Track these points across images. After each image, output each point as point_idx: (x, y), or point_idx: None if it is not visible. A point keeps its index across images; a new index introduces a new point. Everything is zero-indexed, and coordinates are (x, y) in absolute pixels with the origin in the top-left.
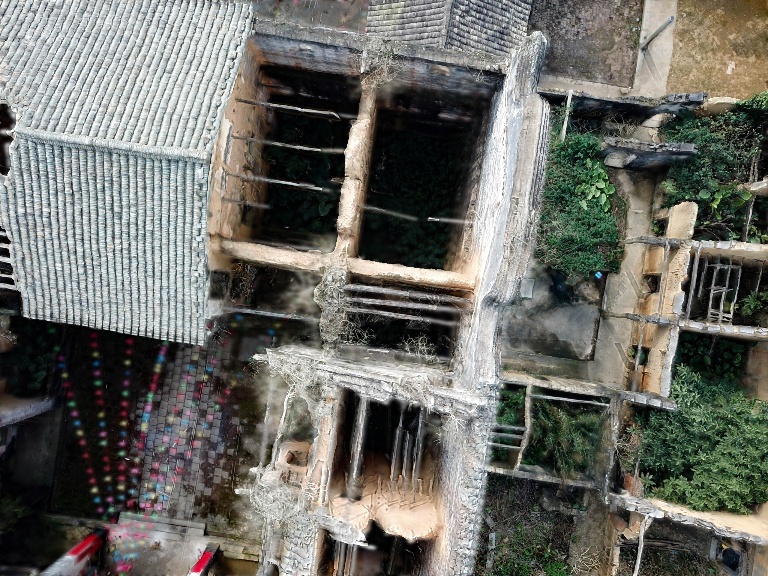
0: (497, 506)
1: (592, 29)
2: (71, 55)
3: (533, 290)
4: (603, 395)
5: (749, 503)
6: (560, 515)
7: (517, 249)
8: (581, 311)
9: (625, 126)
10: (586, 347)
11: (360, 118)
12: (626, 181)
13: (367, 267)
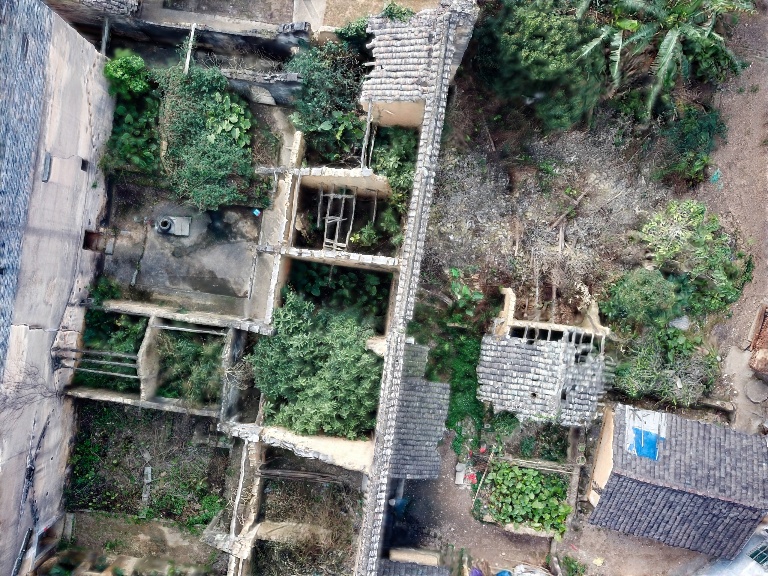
0: (155, 441)
1: None
2: None
3: (190, 228)
4: (226, 326)
5: (362, 429)
6: (217, 449)
7: None
8: (239, 248)
9: (280, 64)
10: (244, 284)
11: None
12: (282, 119)
13: None
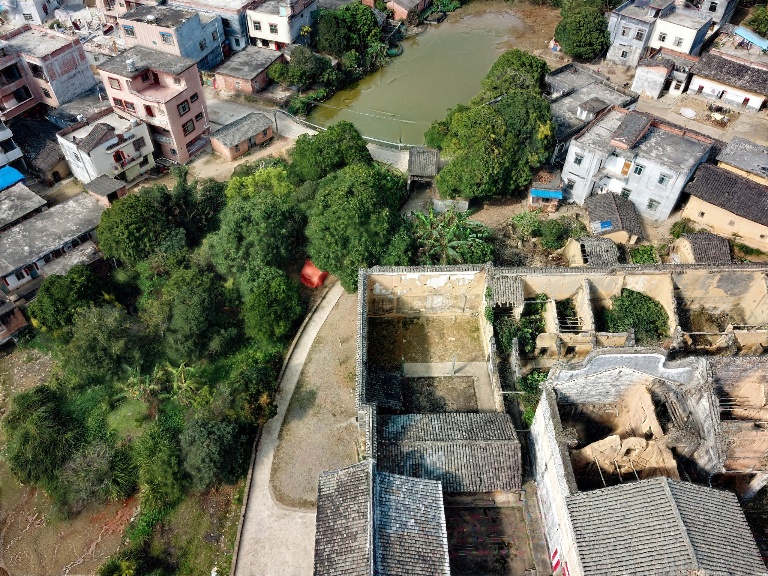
0: None
1: (448, 398)
2: (638, 568)
3: None
4: None
5: None
6: None
7: (652, 348)
8: None
9: None
10: None
11: (584, 454)
12: None
13: (658, 430)
